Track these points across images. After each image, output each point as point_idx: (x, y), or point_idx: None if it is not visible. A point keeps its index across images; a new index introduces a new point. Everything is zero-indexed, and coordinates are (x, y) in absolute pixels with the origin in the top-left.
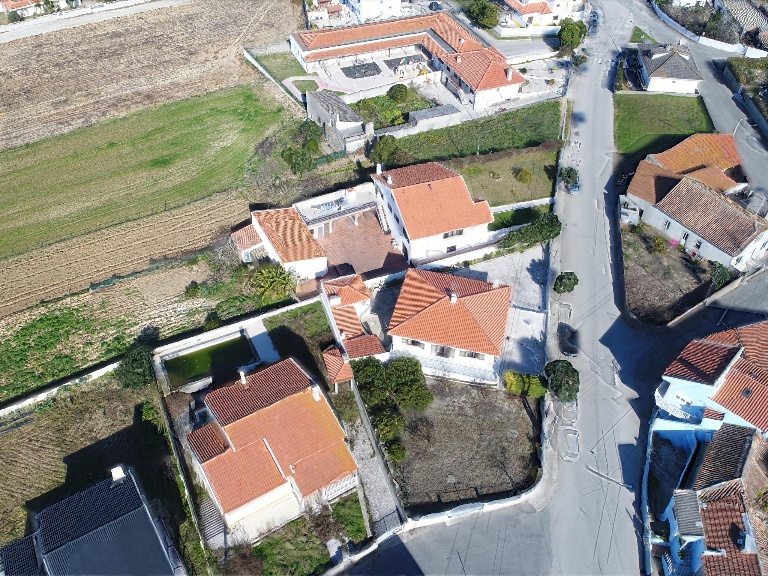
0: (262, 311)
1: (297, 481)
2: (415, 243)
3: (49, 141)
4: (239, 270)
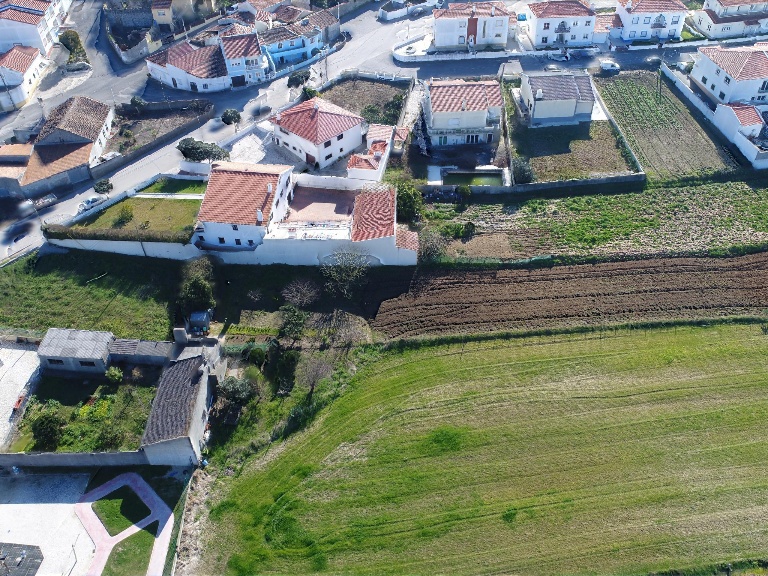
0: (423, 199)
1: None
2: None
3: (613, 574)
4: None
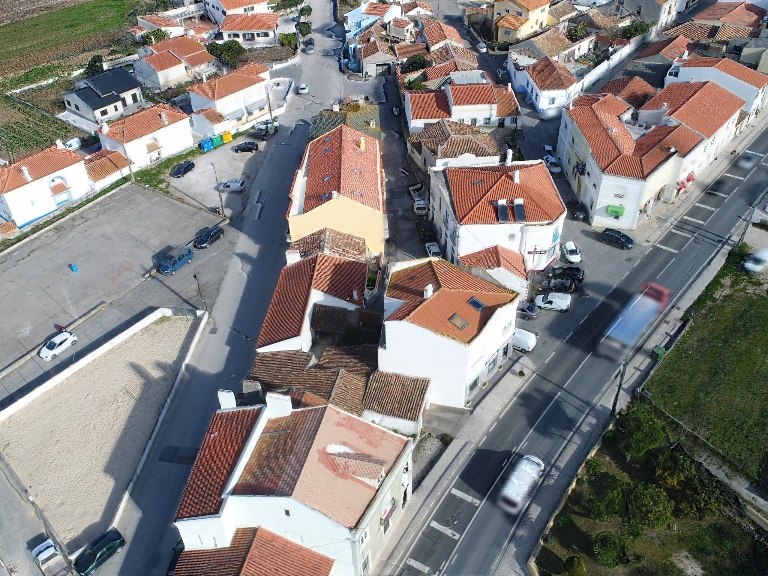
0: None
1: (188, 62)
2: (229, 13)
3: None
4: (137, 44)
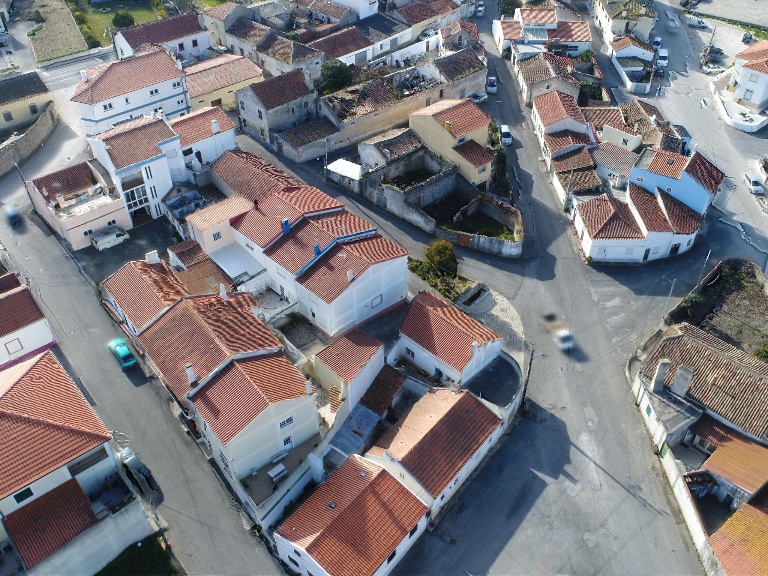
0: None
1: None
2: None
3: None
4: None
